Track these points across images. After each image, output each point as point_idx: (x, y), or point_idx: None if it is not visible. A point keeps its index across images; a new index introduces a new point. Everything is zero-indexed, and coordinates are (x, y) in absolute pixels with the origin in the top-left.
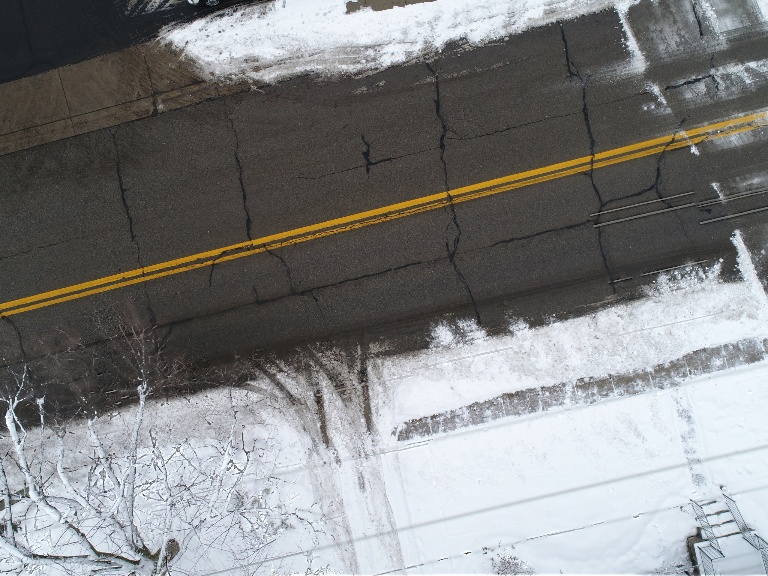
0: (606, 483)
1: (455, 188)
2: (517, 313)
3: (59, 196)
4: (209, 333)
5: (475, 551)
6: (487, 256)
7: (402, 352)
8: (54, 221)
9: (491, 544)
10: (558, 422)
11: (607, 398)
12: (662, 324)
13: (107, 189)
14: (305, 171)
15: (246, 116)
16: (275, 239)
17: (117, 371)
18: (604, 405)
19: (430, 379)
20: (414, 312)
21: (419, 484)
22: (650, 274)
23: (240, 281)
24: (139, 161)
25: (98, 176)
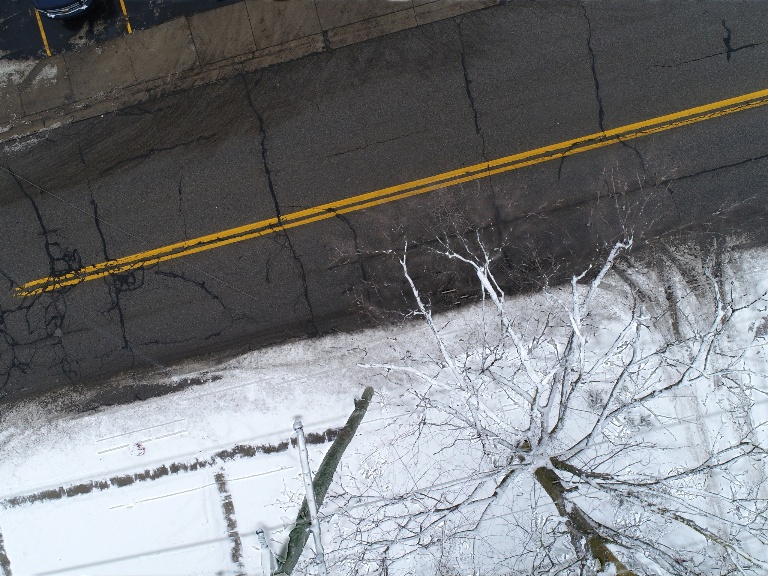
0: None
1: None
2: None
3: (399, 89)
4: (556, 228)
5: None
6: None
7: (759, 245)
8: (394, 115)
9: None
10: None
11: None
12: None
13: (451, 81)
14: (662, 59)
15: (600, 3)
16: (629, 130)
17: (457, 269)
18: None
19: None
20: None
21: None
22: None
23: (591, 174)
24: (485, 51)
25: (441, 67)
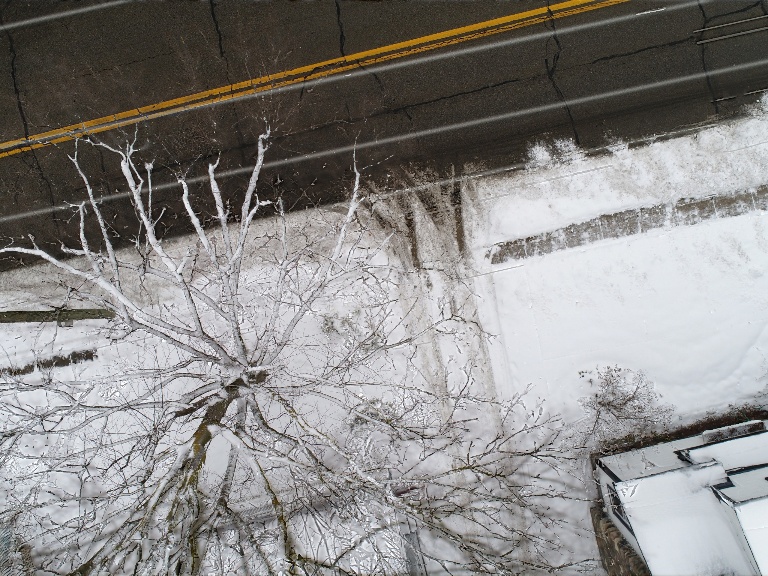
0: (708, 304)
1: (556, 3)
2: (616, 133)
3: (146, 11)
4: None
5: (571, 376)
6: (587, 73)
7: (497, 173)
8: (140, 37)
9: (588, 367)
10: (659, 242)
11: (708, 220)
12: (767, 140)
13: (196, 4)
14: None
15: None
16: (369, 55)
17: (201, 193)
18: (706, 225)
19: (527, 198)
20: (510, 131)
21: (515, 305)
22: (754, 93)
23: (332, 98)
24: None
25: None
